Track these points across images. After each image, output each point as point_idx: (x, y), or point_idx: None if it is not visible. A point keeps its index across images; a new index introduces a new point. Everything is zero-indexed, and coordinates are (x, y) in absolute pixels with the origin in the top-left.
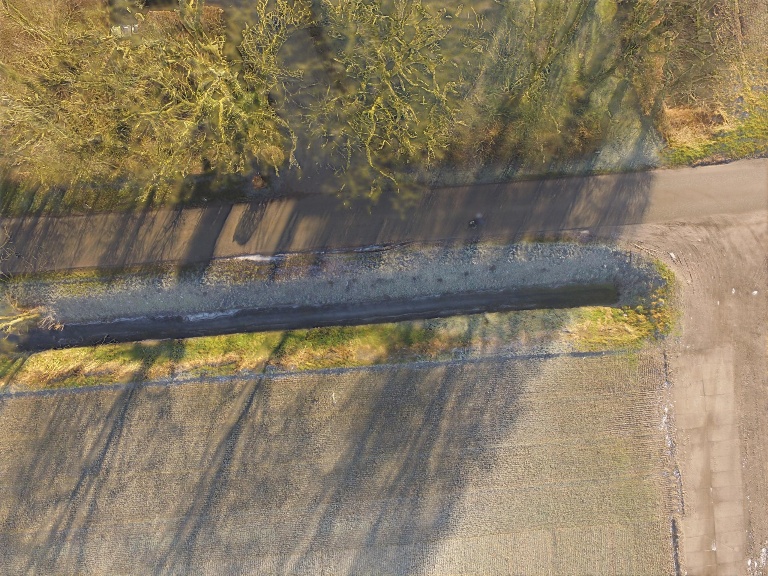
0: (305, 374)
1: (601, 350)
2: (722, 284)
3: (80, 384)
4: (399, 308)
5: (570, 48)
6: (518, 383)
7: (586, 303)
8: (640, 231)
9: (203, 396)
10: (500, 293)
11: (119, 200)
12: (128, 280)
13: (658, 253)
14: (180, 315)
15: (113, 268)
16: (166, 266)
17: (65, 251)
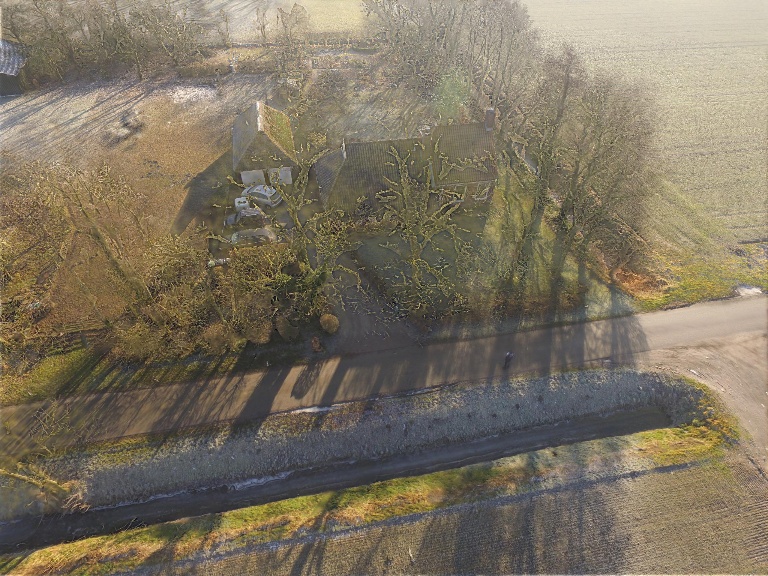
0: (373, 528)
1: (684, 461)
2: (753, 389)
3: (90, 574)
4: (460, 452)
5: (535, 253)
6: (618, 509)
7: (643, 428)
8: (653, 356)
9: (248, 573)
10: (556, 427)
11: (186, 373)
12: (180, 442)
13: (680, 371)
14: (226, 484)
15: (166, 432)
16: (222, 425)
17: (121, 421)
